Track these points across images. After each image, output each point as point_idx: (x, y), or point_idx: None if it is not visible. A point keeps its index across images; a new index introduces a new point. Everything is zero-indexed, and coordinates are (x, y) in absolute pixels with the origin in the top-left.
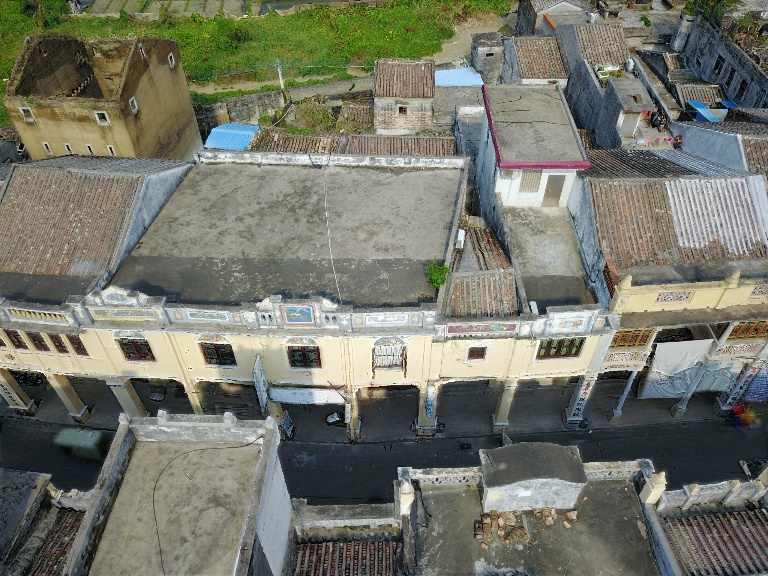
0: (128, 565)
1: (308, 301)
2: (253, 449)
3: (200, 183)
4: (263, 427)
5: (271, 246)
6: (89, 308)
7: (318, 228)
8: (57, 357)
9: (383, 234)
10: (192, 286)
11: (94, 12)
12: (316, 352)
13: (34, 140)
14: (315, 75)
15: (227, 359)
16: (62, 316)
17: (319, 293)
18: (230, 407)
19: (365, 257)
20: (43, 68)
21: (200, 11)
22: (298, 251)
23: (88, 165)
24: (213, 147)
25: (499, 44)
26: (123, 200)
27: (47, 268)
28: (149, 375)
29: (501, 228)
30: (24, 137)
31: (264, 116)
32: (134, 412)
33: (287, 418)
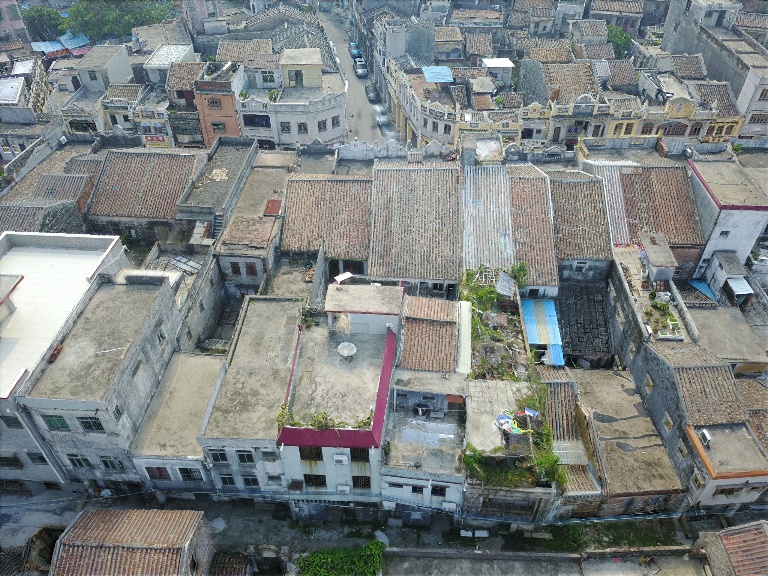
0: None
1: None
2: None
3: None
4: None
5: None
6: None
7: None
8: None
9: None
10: None
11: None
12: None
13: None
14: None
15: None
16: None
17: None
18: None
19: None
20: None
21: None
22: None
23: None
24: None
25: None
26: None
27: None
28: None
29: None
30: None
31: None
32: None
33: None
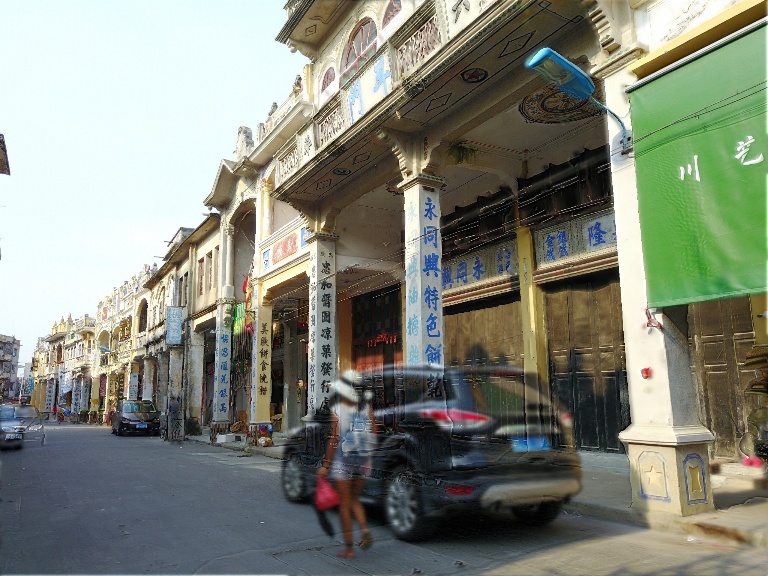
0: None
1: None
2: None
3: None
4: None
5: None
6: None
7: None
8: None
9: None
10: None
11: None
12: None
13: None
14: None
15: None
16: None
17: None
18: None
19: None
20: None
21: None
22: None
23: None
24: None
25: None
26: None
27: None
28: None
29: None
30: None
31: None
32: None
33: None
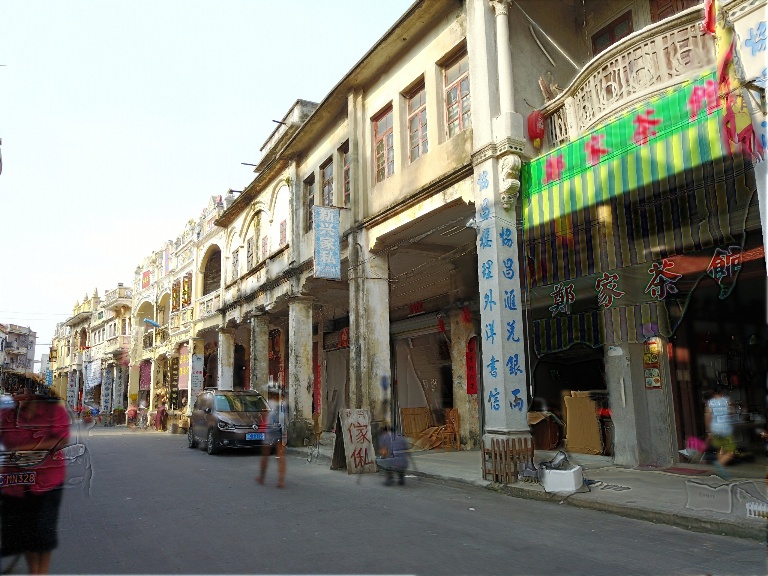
0: None
1: None
2: None
3: None
4: None
5: None
6: None
7: None
8: None
9: None
10: None
11: None
12: None
13: None
14: None
15: None
16: None
17: None
18: None
19: None
20: None
21: None
22: None
23: None
24: None
25: None
26: None
27: None
28: None
29: None
30: None
31: None
32: None
33: None
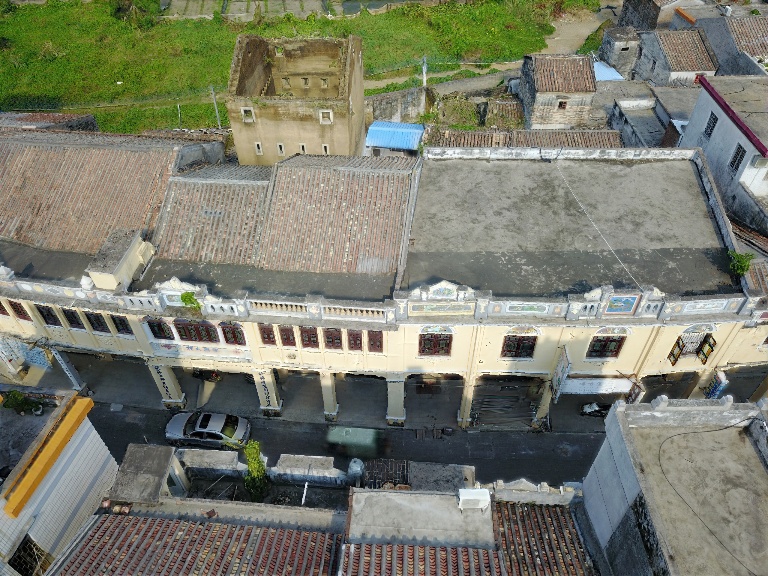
0: (690, 546)
1: (638, 290)
2: (733, 432)
3: (438, 179)
4: (757, 409)
5: (544, 239)
6: (409, 304)
7: (581, 220)
8: (346, 355)
9: (648, 225)
10: (487, 280)
11: (174, 14)
12: (618, 341)
13: (247, 141)
14: (430, 73)
15: (524, 351)
16: (380, 313)
17: (617, 283)
18: (500, 400)
19: (643, 247)
20: (248, 68)
21: (282, 11)
22: (574, 243)
23: (338, 163)
24: (374, 145)
25: (636, 38)
26: (398, 197)
27: (333, 266)
28: (436, 370)
29: (755, 216)
30: (237, 138)
31: (405, 114)
32: (398, 408)
33: (548, 409)
